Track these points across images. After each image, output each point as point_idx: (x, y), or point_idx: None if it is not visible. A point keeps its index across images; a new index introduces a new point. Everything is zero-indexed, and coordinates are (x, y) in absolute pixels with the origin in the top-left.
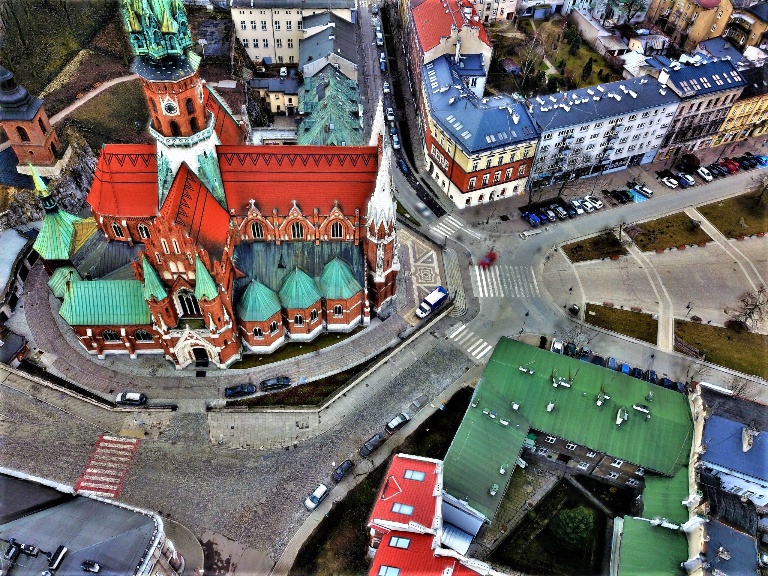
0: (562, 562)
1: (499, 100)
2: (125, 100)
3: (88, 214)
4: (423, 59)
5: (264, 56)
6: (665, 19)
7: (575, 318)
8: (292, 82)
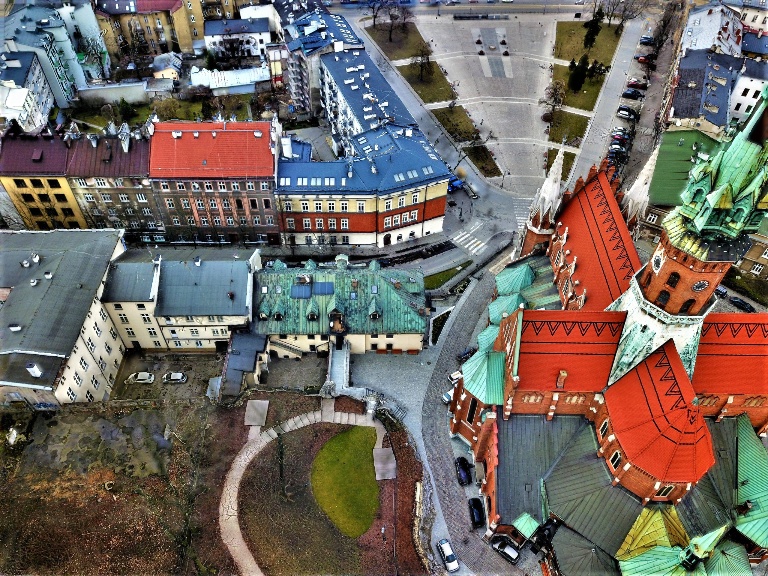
0: None
1: (371, 140)
2: (304, 567)
3: (600, 567)
4: (273, 184)
5: (101, 399)
6: (126, 46)
7: (564, 185)
8: (238, 340)
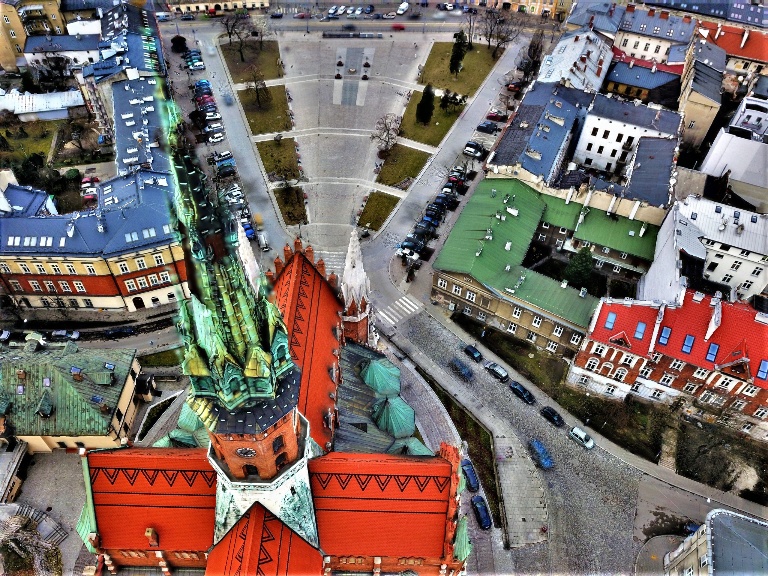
0: (590, 288)
1: (117, 189)
2: None
3: None
4: None
5: None
6: None
7: (373, 236)
8: None
